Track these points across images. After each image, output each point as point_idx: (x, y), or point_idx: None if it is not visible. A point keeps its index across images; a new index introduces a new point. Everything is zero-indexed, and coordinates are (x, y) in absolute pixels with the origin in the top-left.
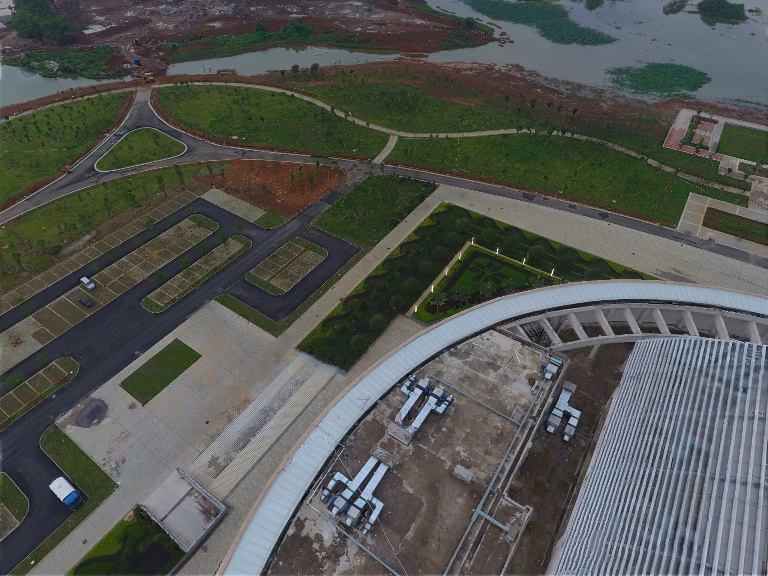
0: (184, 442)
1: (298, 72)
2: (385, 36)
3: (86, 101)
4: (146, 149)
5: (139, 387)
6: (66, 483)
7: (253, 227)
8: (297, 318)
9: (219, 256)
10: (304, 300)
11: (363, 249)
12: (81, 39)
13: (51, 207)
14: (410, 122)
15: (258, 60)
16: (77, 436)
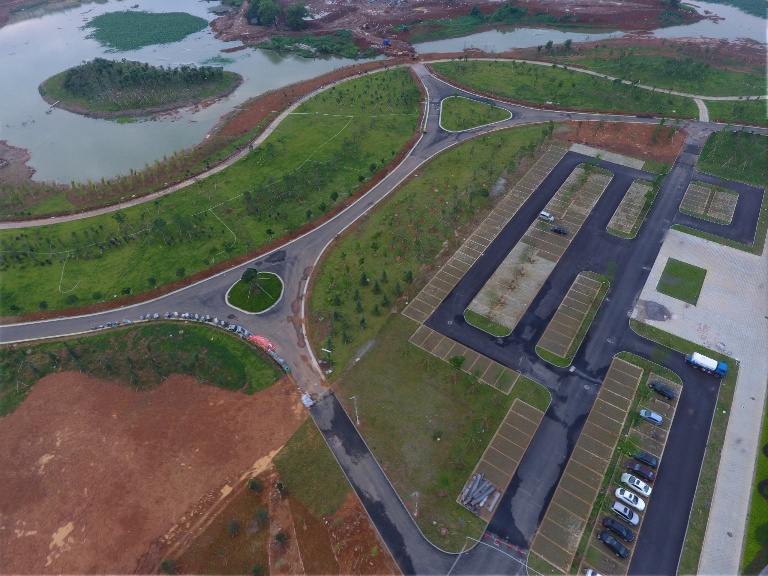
0: (762, 331)
1: (551, 48)
2: (603, 16)
3: (375, 76)
4: (477, 113)
5: (676, 293)
6: (705, 356)
7: (645, 173)
8: (764, 242)
9: (638, 196)
10: (754, 228)
11: (766, 189)
12: (313, 25)
13: (441, 160)
14: (703, 87)
15: (489, 40)
16: (662, 327)
